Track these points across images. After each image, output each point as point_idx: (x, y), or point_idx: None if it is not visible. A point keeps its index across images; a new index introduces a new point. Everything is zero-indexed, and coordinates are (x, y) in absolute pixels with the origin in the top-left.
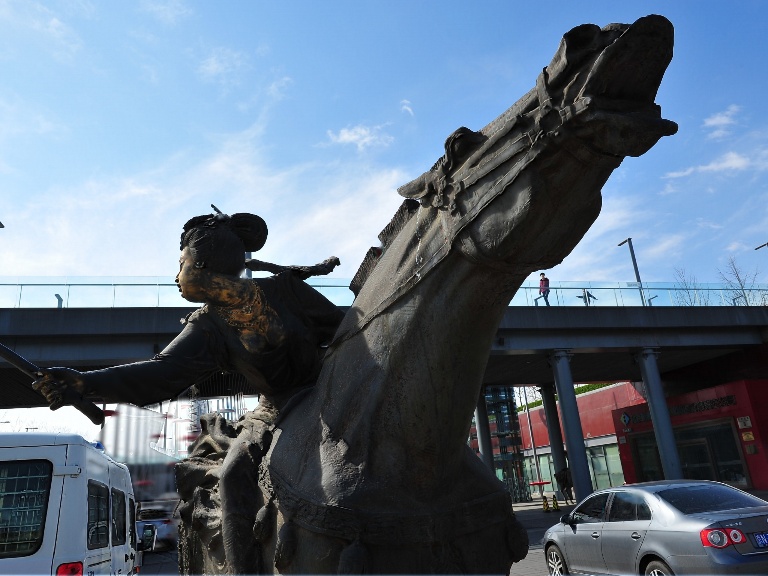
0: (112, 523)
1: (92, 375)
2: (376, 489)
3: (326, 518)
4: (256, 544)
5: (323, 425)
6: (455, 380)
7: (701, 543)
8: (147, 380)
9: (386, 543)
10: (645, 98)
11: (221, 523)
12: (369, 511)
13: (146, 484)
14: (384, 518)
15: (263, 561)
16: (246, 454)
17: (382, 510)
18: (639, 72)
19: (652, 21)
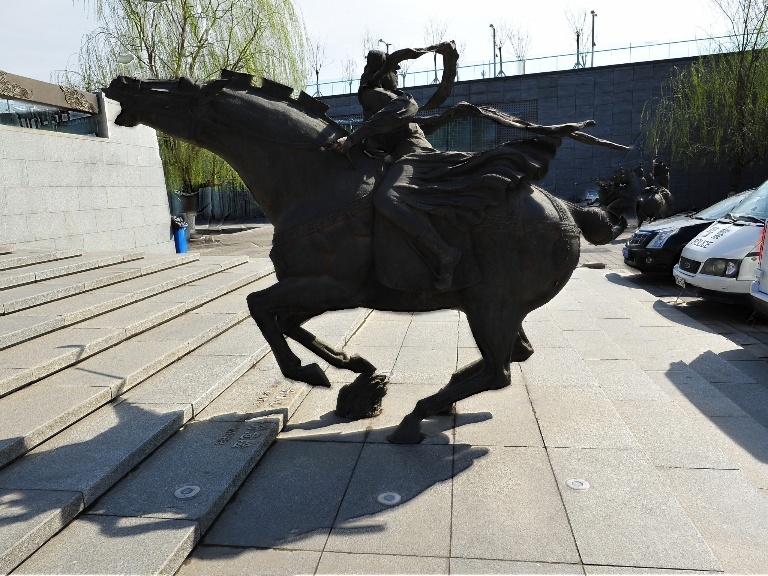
0: None
1: None
2: None
3: None
4: None
5: None
6: None
7: None
8: None
9: None
10: None
11: None
12: None
13: None
14: None
15: None
16: None
17: None
18: None
19: None
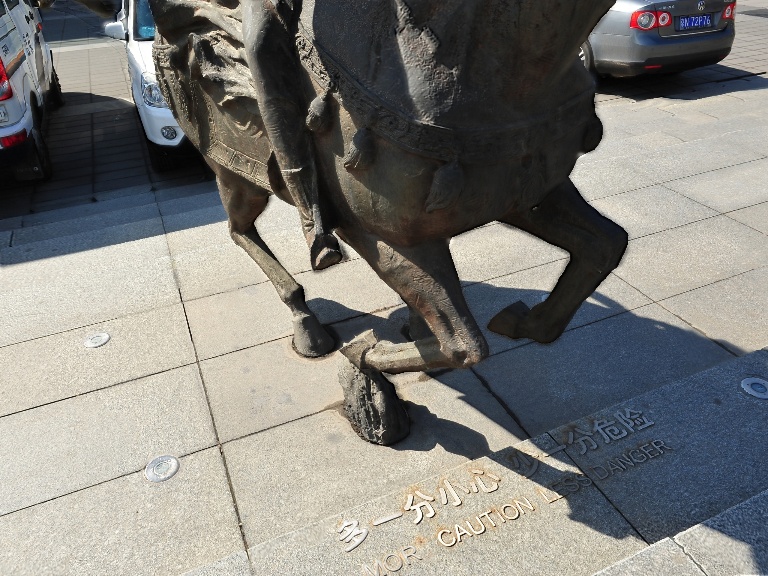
0: None
1: None
2: (475, 102)
3: (421, 138)
4: (306, 131)
5: (397, 1)
6: None
7: (629, 24)
8: None
9: (482, 161)
10: None
11: (252, 98)
12: (467, 128)
13: None
14: (482, 135)
15: (317, 149)
16: (274, 17)
17: (480, 126)
18: None
19: None
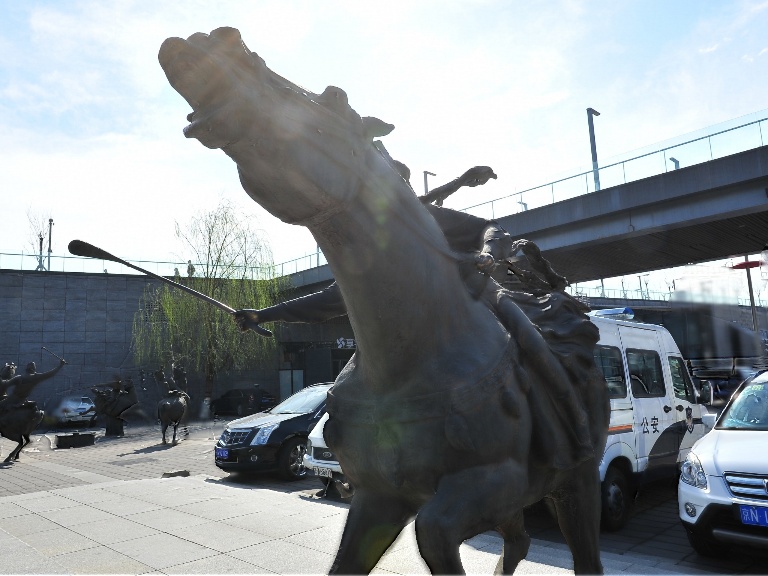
0: (631, 378)
1: (265, 311)
2: (351, 383)
3: None
4: None
5: None
6: (353, 305)
7: None
8: (308, 307)
9: (347, 421)
10: (224, 87)
11: None
12: (344, 398)
13: (691, 343)
14: (349, 404)
15: None
16: None
17: (351, 398)
18: (196, 81)
19: (165, 50)
